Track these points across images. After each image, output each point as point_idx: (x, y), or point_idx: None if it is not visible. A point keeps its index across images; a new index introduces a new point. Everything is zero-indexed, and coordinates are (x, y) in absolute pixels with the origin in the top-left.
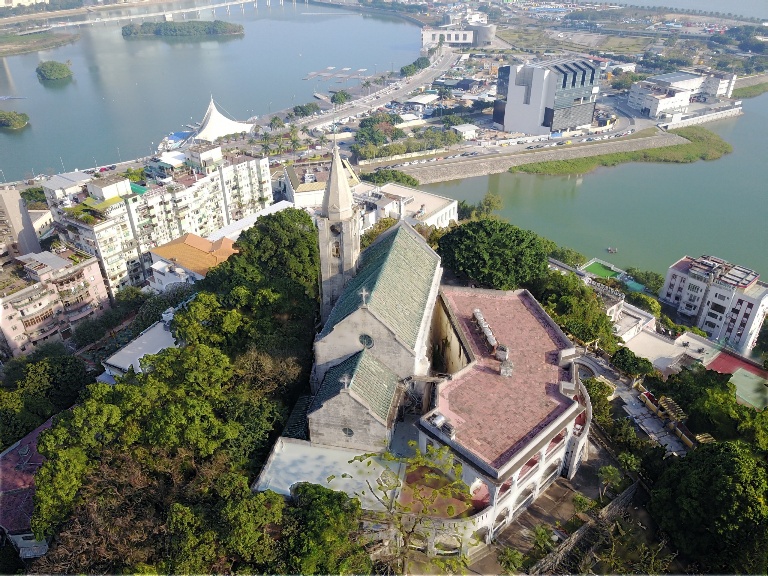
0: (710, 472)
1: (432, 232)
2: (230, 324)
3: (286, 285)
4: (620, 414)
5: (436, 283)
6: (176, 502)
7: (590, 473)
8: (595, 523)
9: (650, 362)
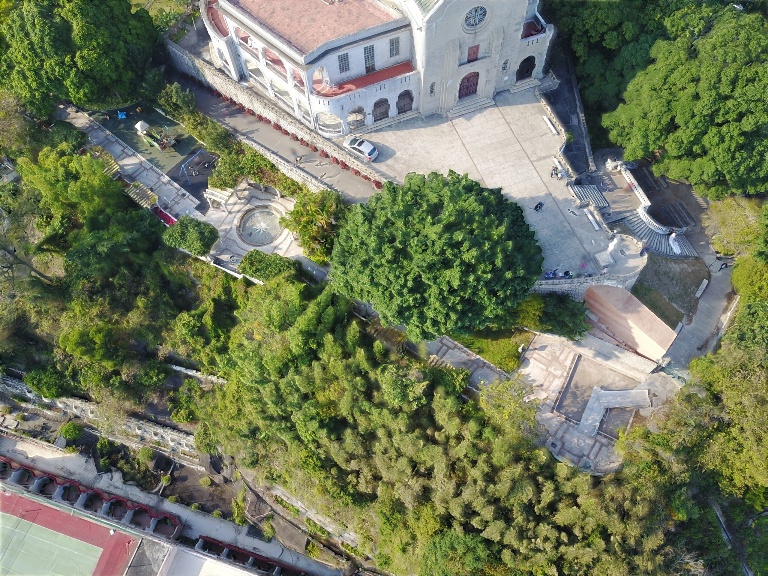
0: (101, 6)
1: (651, 434)
2: None
3: None
4: (201, 190)
5: (405, 2)
6: None
7: (205, 36)
8: (195, 3)
9: (166, 237)
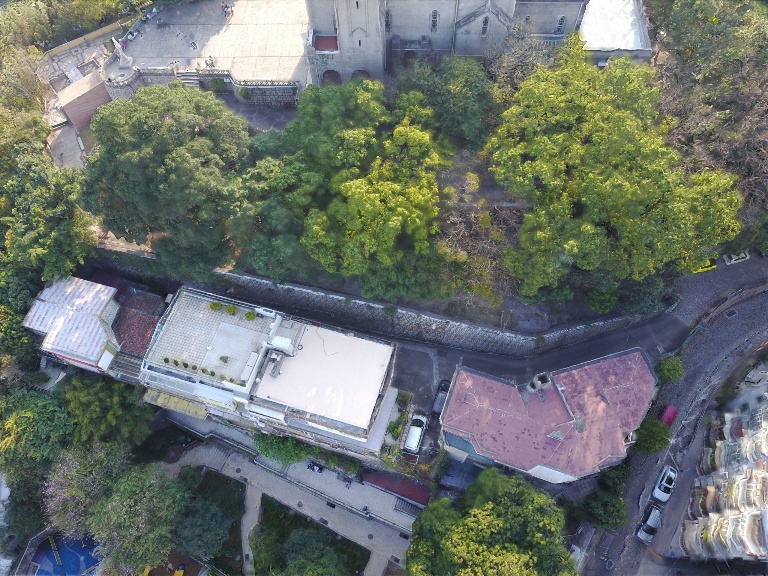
0: None
1: None
2: (418, 136)
3: (315, 100)
4: None
5: None
6: (694, 90)
7: None
8: None
9: None
